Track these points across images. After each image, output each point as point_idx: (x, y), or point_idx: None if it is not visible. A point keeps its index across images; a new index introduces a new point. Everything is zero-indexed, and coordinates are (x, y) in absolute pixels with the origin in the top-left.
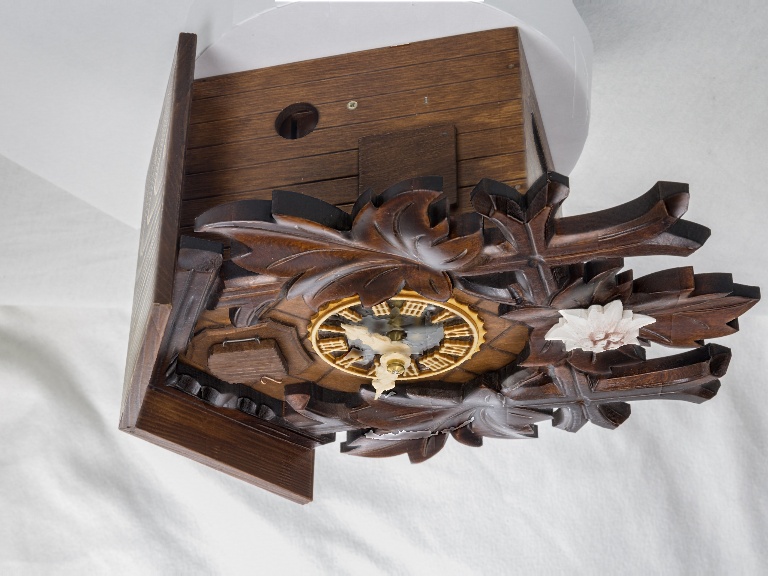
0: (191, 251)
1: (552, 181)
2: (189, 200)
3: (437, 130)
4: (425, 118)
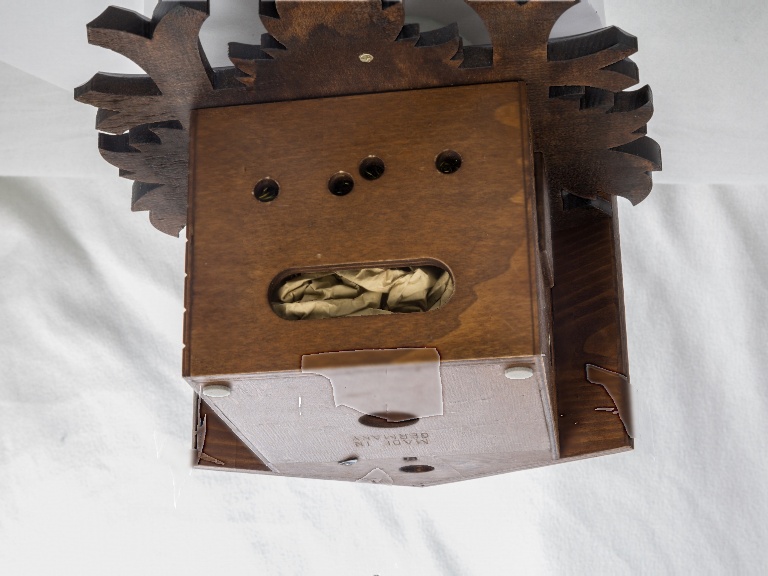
0: (605, 200)
1: None
2: None
3: None
4: None
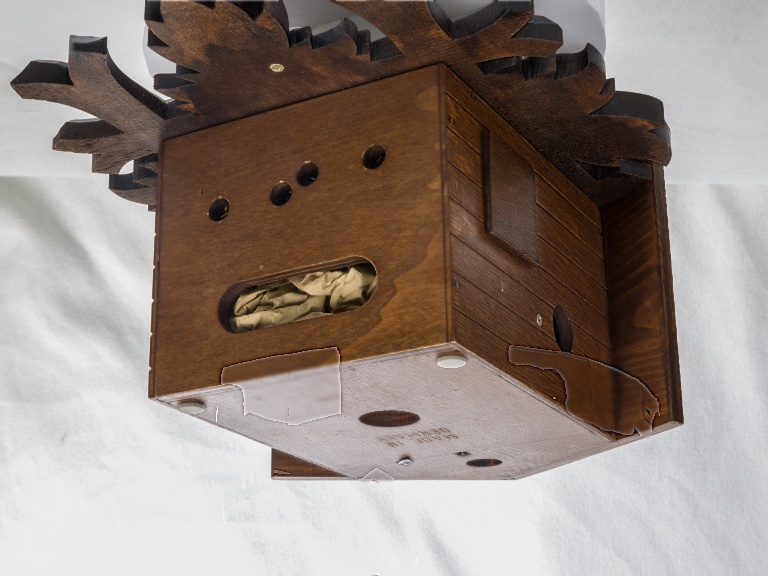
0: None
1: (530, 0)
2: (601, 285)
3: (502, 232)
4: (502, 263)
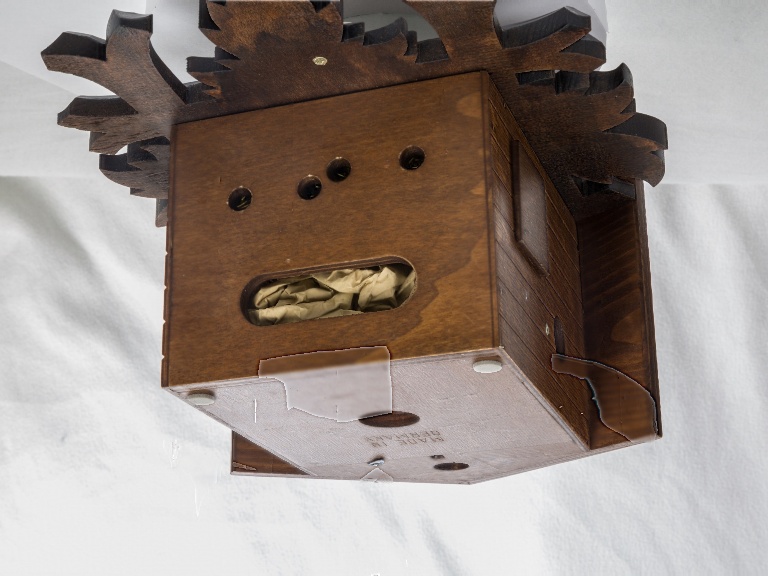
0: (627, 183)
1: (587, 17)
2: None
3: None
4: None
